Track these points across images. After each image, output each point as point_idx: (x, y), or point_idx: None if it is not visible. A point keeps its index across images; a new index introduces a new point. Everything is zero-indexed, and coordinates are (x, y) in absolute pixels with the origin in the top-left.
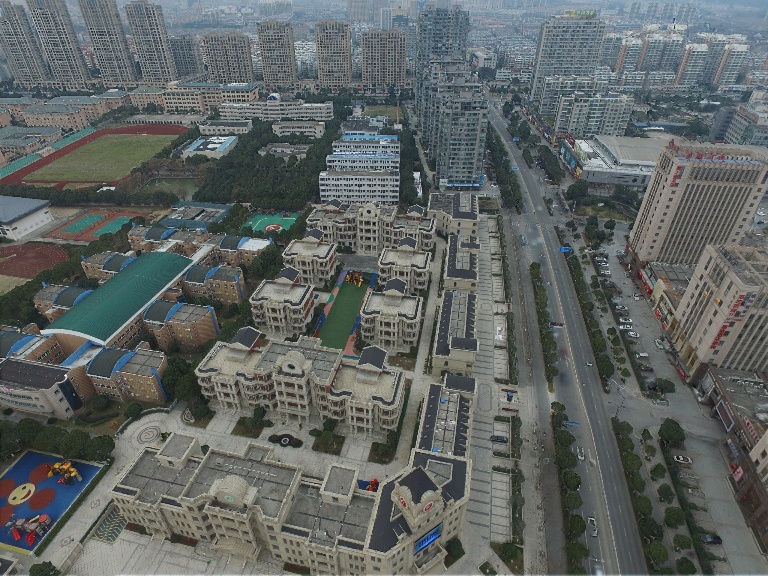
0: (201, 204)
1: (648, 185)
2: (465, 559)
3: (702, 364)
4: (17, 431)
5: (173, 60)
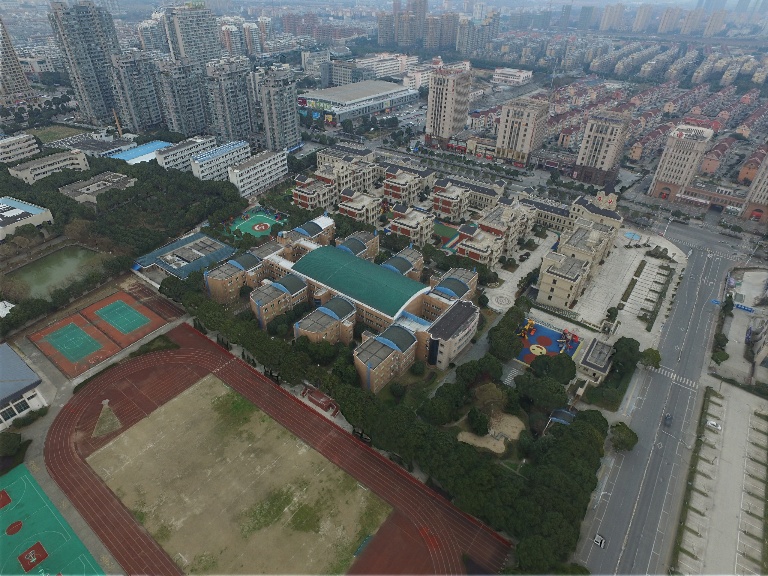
0: (173, 246)
1: (429, 98)
2: None
3: (528, 154)
4: None
5: None
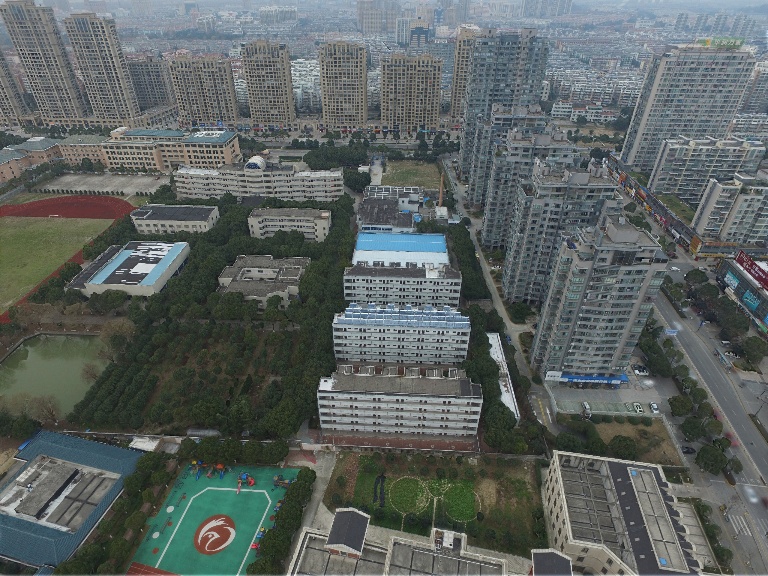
0: (73, 454)
1: None
2: None
3: None
4: None
5: (133, 90)
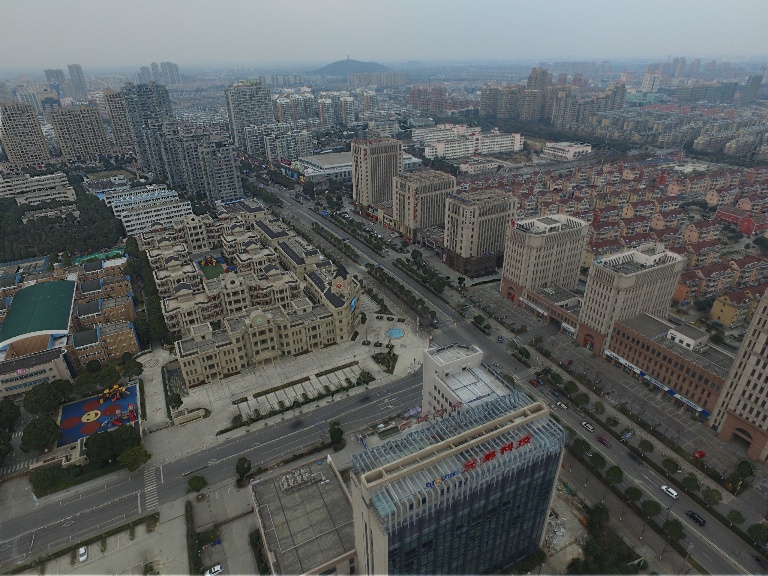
0: (12, 263)
1: None
2: (368, 320)
3: (414, 230)
4: (56, 387)
5: None
